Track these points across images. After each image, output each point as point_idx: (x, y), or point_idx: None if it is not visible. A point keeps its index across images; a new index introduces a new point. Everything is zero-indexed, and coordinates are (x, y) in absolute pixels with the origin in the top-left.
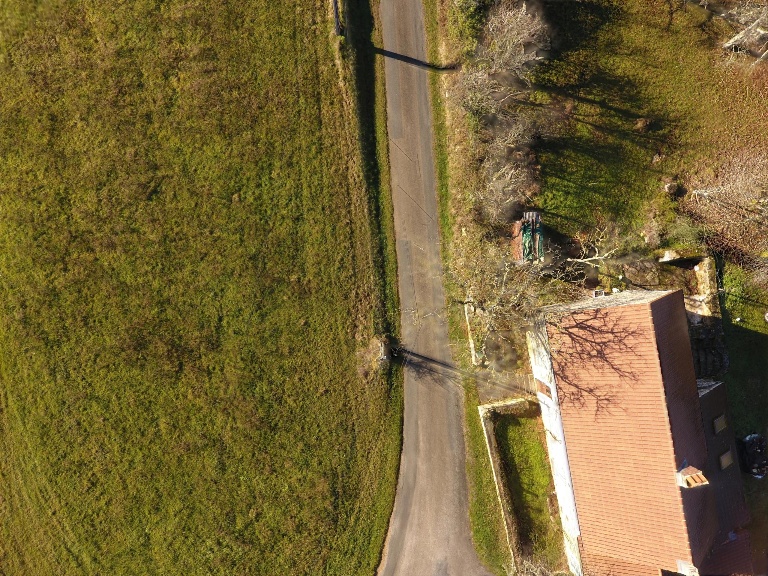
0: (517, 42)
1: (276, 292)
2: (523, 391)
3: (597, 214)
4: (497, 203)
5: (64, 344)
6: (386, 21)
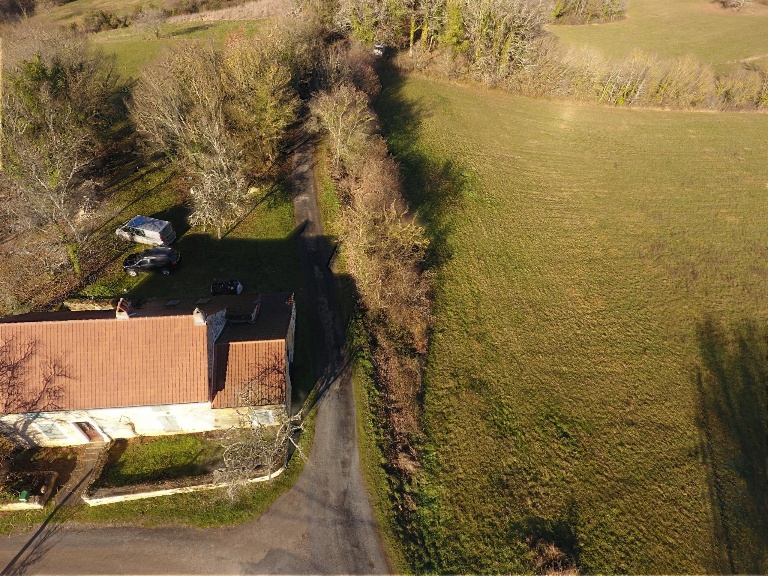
0: None
1: None
2: None
3: None
4: None
5: None
6: None
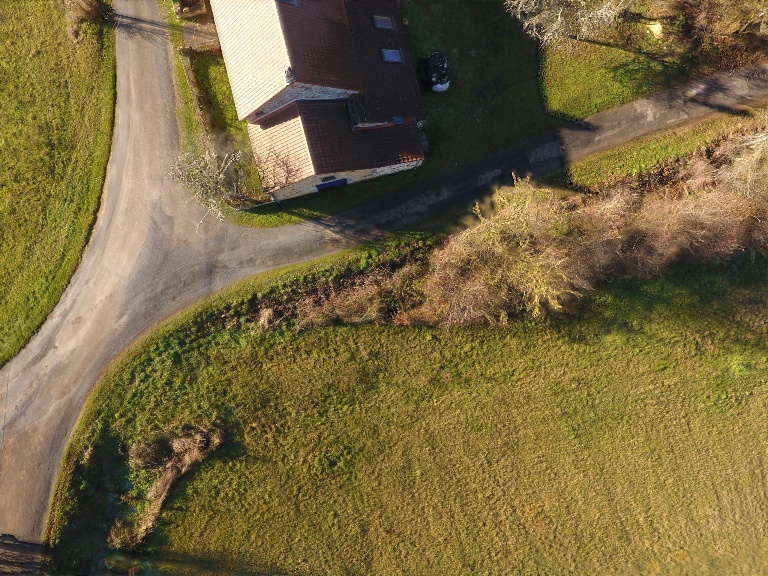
0: None
1: None
2: None
3: None
4: None
5: None
6: None
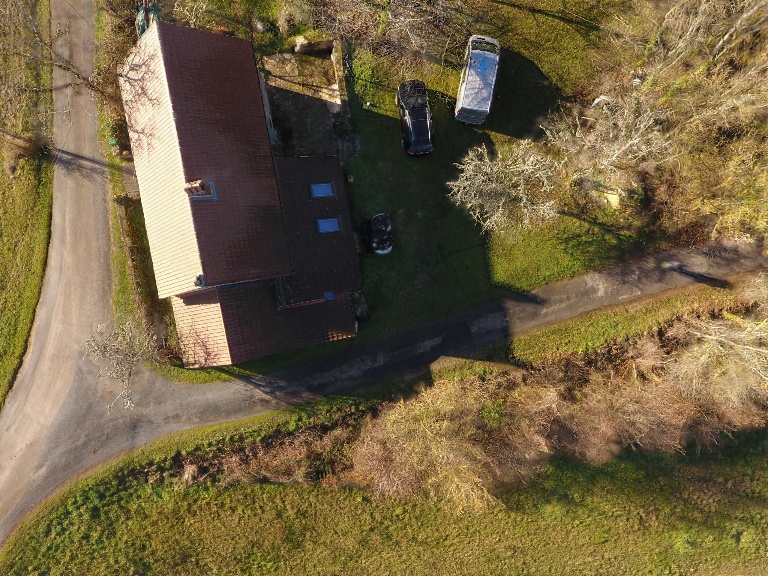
0: None
1: None
2: None
3: (235, 6)
4: None
5: None
6: None
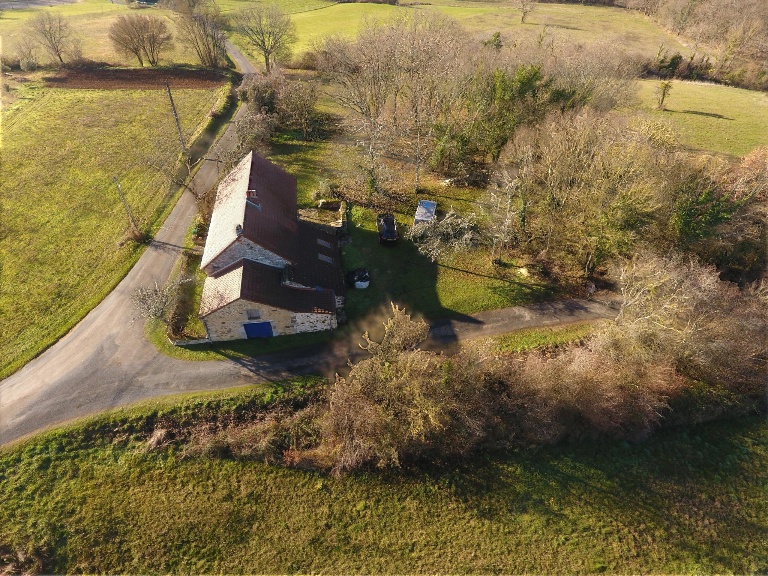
0: (242, 120)
1: (90, 215)
2: None
3: None
4: (216, 160)
5: None
6: (213, 153)
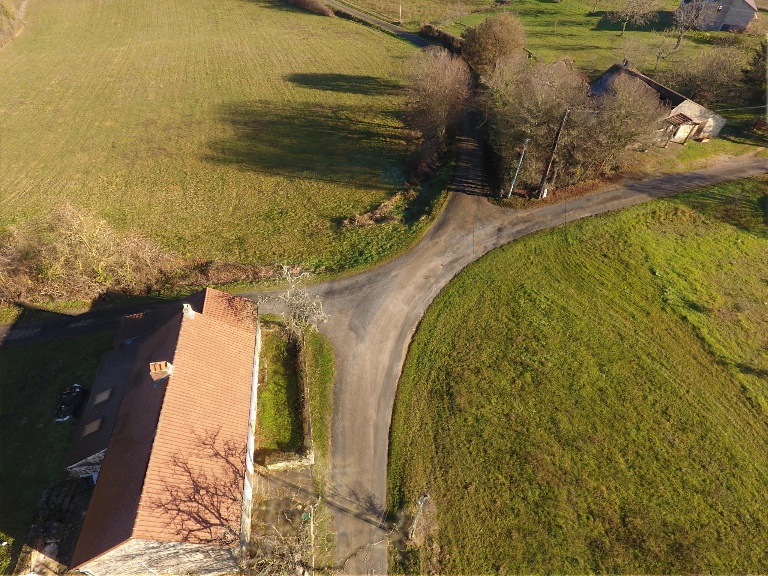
0: None
1: None
2: (266, 477)
3: None
4: None
5: (762, 556)
6: None
